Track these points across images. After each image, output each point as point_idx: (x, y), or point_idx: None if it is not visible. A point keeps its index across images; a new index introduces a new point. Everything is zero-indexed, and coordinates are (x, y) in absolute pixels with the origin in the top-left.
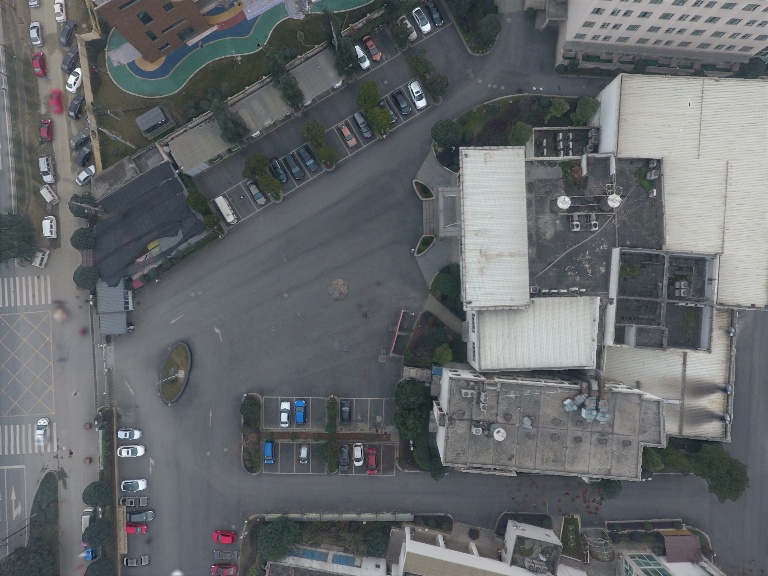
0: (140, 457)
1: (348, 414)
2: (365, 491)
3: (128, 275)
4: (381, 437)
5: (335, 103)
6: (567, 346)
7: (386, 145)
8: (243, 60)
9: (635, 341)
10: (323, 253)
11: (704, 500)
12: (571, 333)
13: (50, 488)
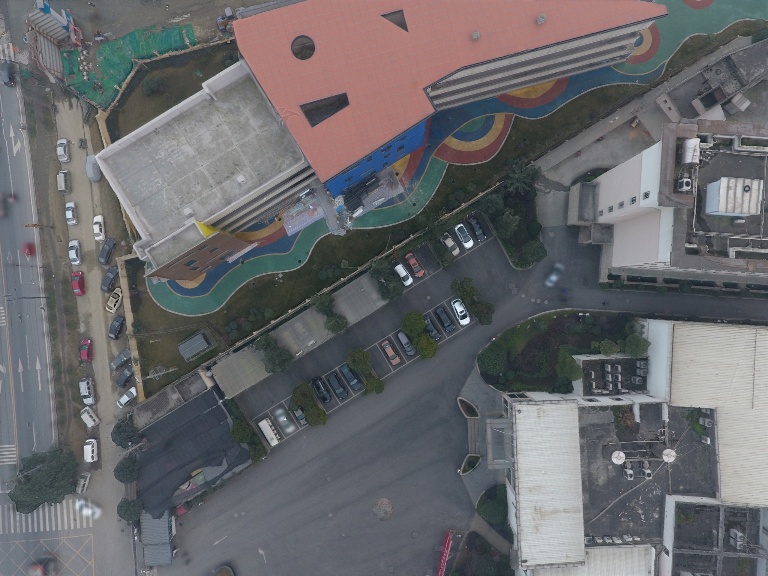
0: None
1: None
2: None
3: (172, 506)
4: None
5: (378, 319)
6: None
7: (430, 361)
8: (284, 277)
9: None
10: (367, 472)
11: None
12: None
13: None
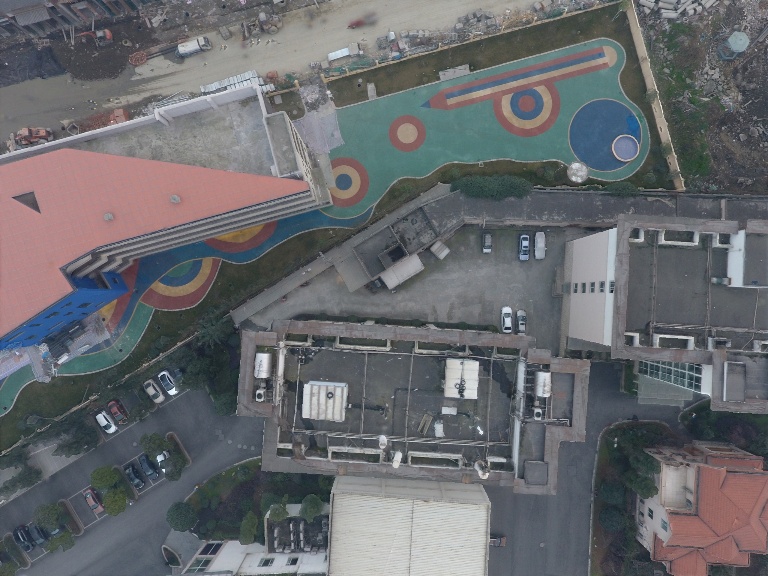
0: None
1: None
2: None
3: None
4: None
5: (83, 466)
6: None
7: (135, 509)
8: None
9: None
10: None
11: None
12: None
13: None
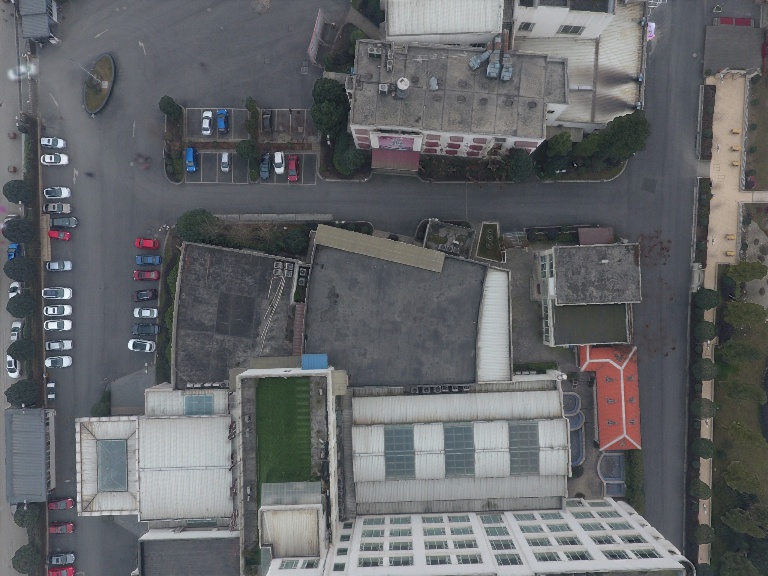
0: (64, 168)
1: (269, 120)
2: (286, 200)
3: None
4: (302, 146)
5: None
6: (474, 13)
7: None
8: None
9: None
10: None
11: (621, 206)
12: (478, 1)
13: None
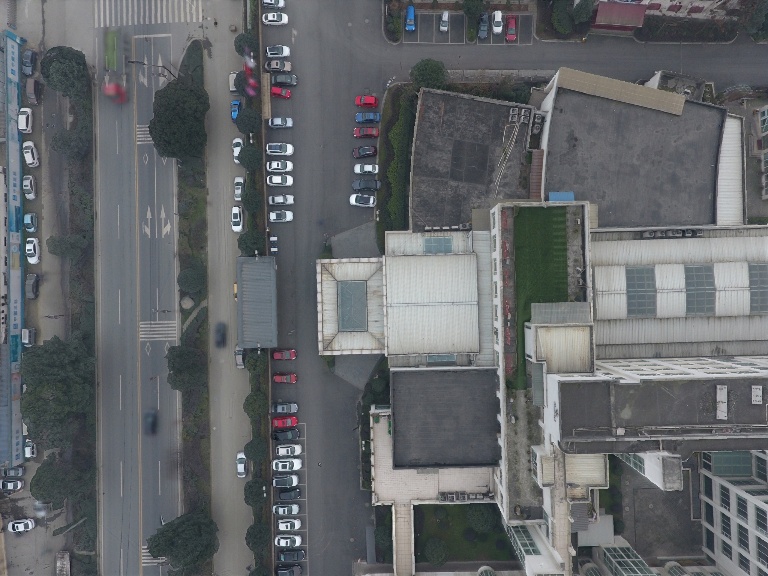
0: (283, 28)
1: None
2: (503, 60)
3: None
4: (519, 7)
5: None
6: None
7: None
8: None
9: None
10: None
11: None
12: None
13: (197, 53)
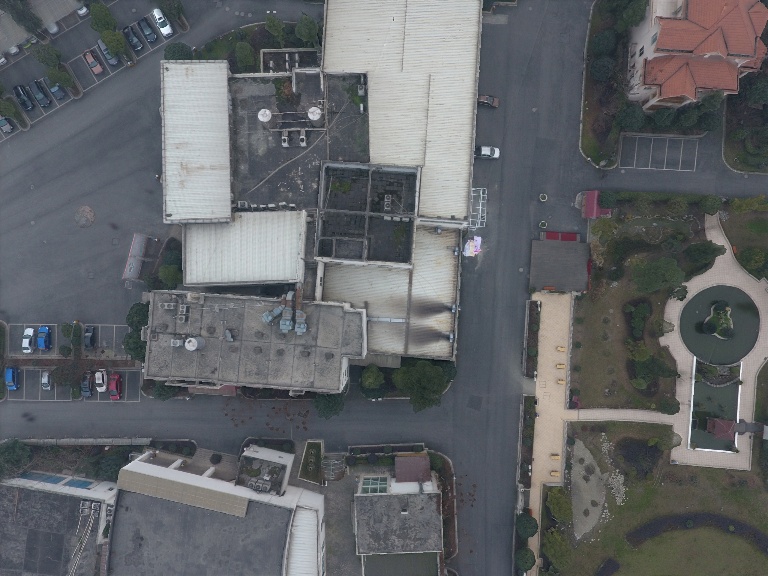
0: None
1: (89, 339)
2: (110, 417)
3: None
4: (125, 363)
5: (83, 31)
6: (273, 260)
7: (133, 73)
8: None
9: (333, 252)
10: (70, 180)
11: (447, 424)
12: (277, 247)
13: None
